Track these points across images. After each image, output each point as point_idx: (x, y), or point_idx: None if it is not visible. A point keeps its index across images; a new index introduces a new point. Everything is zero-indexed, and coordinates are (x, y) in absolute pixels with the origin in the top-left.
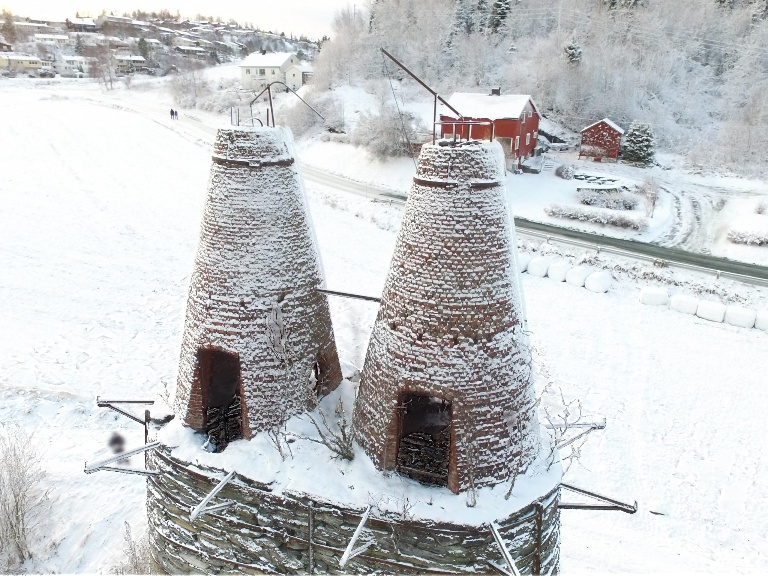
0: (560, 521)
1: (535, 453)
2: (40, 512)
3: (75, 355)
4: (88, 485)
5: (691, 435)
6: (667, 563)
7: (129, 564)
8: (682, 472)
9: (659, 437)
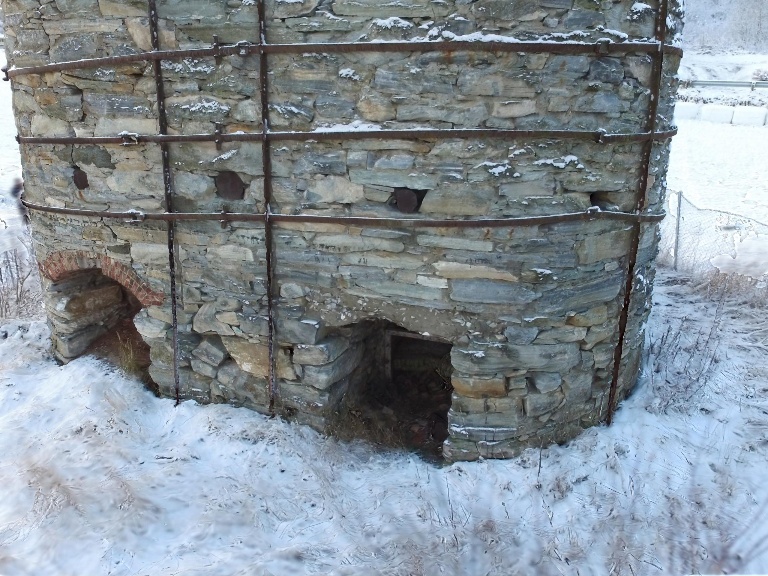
0: None
1: None
2: None
3: (2, 167)
4: None
5: (755, 178)
6: (759, 246)
7: (28, 260)
8: (753, 199)
9: (716, 182)
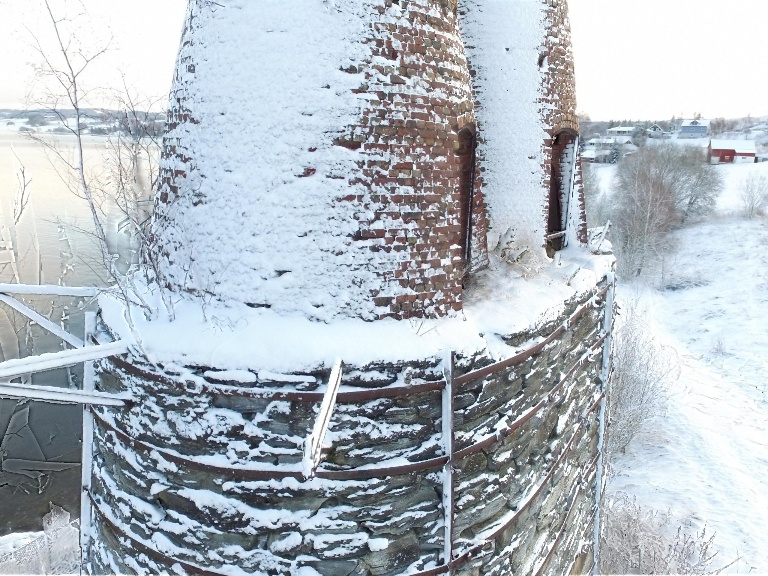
0: (155, 483)
1: (174, 279)
2: (654, 453)
3: None
4: (702, 465)
5: None
6: None
7: None
8: None
9: None
